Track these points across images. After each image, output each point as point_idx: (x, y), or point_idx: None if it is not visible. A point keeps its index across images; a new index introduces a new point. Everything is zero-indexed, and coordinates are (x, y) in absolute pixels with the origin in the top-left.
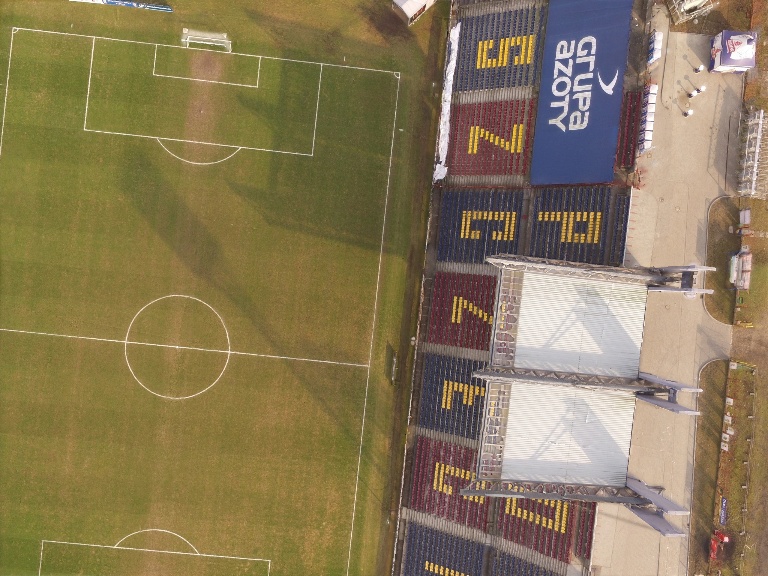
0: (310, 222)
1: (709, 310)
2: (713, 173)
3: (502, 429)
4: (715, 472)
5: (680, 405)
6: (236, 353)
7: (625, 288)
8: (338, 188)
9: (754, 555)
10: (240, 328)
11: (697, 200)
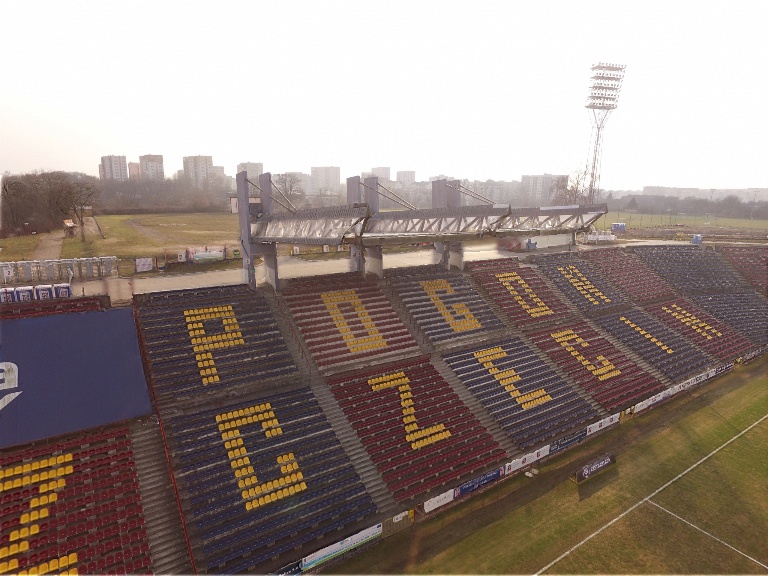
0: None
1: None
2: (90, 283)
3: None
4: None
5: None
6: None
7: None
8: None
9: None
10: None
11: None
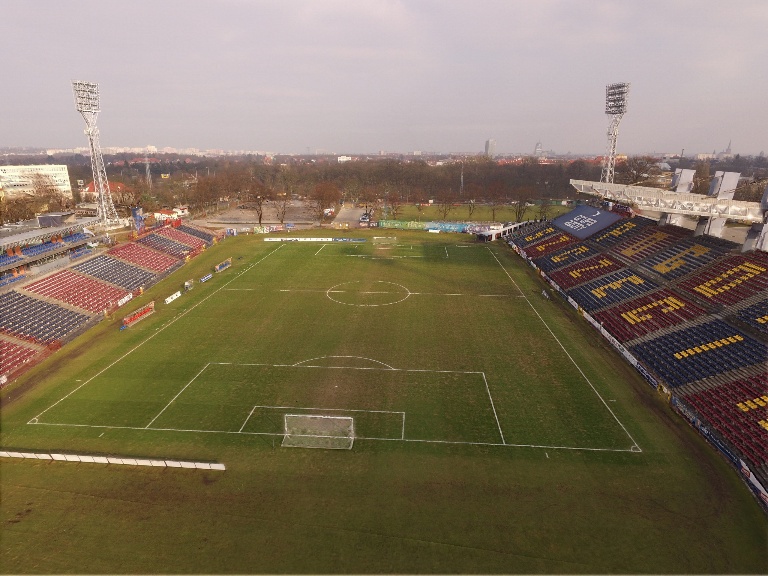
0: (454, 267)
1: None
2: None
3: None
4: None
5: None
6: None
7: None
8: None
9: None
10: None
11: None
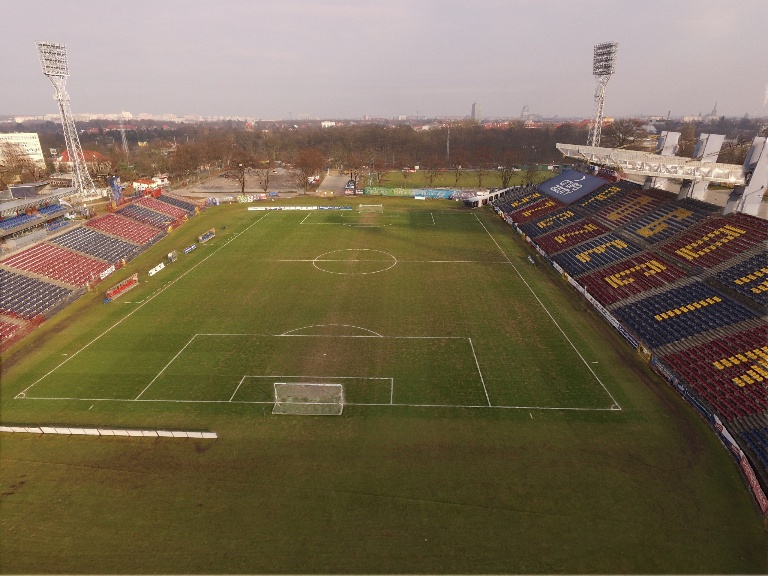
0: None
1: None
2: None
3: None
4: None
5: None
6: (402, 261)
7: None
8: (454, 228)
9: None
10: (403, 255)
11: None
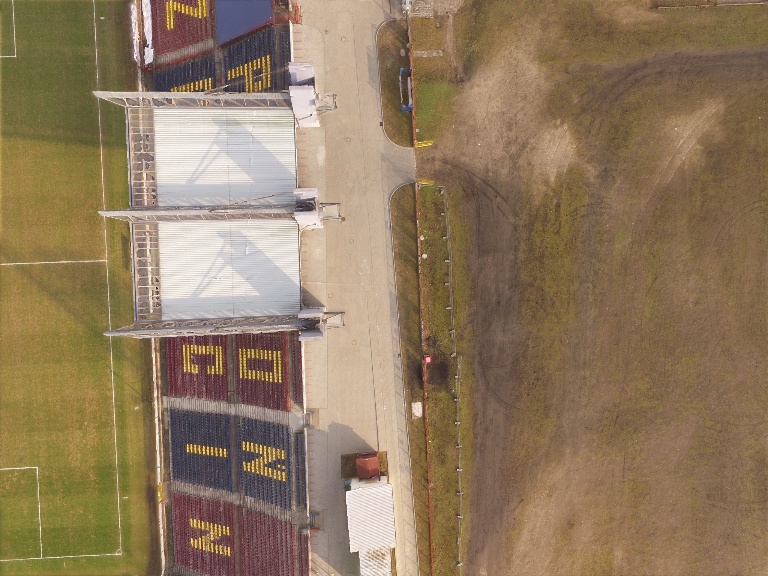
0: (24, 124)
1: (389, 136)
2: None
3: (155, 270)
4: (417, 298)
5: (318, 216)
6: None
7: (268, 114)
8: (47, 86)
9: (469, 375)
10: None
11: (363, 27)
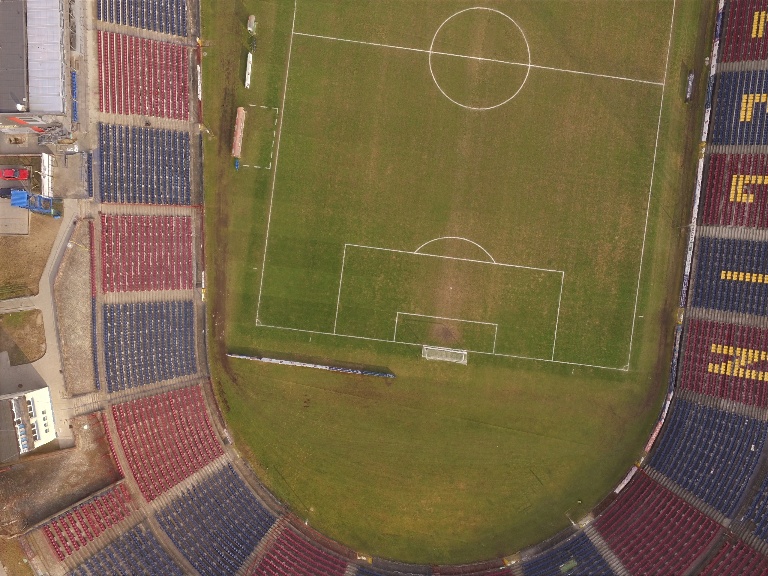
0: None
1: None
2: None
3: None
4: None
5: None
6: (536, 67)
7: None
8: None
9: None
10: (540, 42)
11: None
